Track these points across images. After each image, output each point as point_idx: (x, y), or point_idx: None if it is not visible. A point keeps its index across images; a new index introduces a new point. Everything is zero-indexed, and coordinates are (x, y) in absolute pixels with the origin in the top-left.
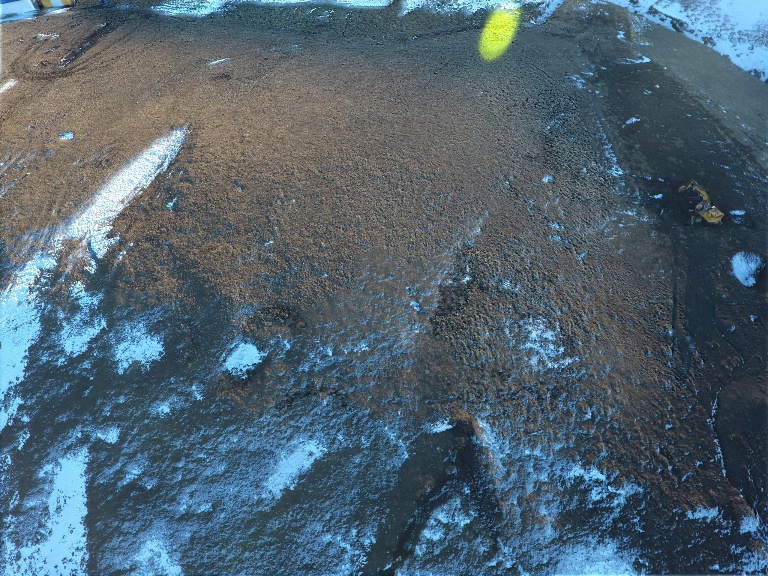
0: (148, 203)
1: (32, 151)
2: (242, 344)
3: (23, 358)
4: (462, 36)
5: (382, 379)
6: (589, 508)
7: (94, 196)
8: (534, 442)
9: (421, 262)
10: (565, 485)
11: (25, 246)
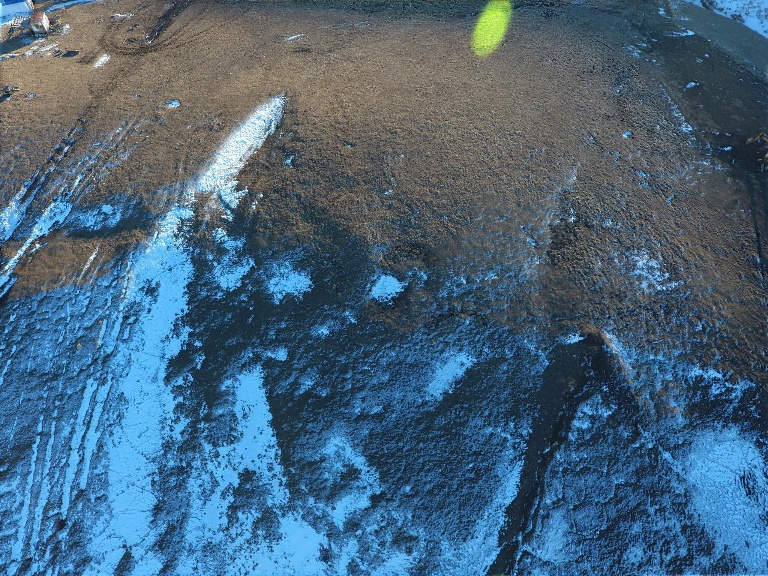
0: (267, 161)
1: (145, 117)
2: (383, 276)
3: (183, 294)
4: (518, 12)
5: (514, 302)
6: (711, 400)
7: (214, 155)
8: (656, 349)
9: (530, 205)
10: (688, 382)
11: (162, 199)
